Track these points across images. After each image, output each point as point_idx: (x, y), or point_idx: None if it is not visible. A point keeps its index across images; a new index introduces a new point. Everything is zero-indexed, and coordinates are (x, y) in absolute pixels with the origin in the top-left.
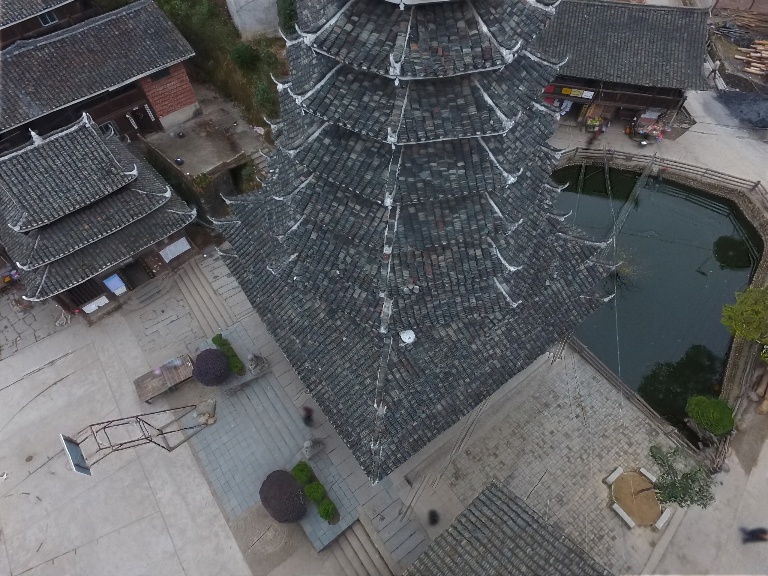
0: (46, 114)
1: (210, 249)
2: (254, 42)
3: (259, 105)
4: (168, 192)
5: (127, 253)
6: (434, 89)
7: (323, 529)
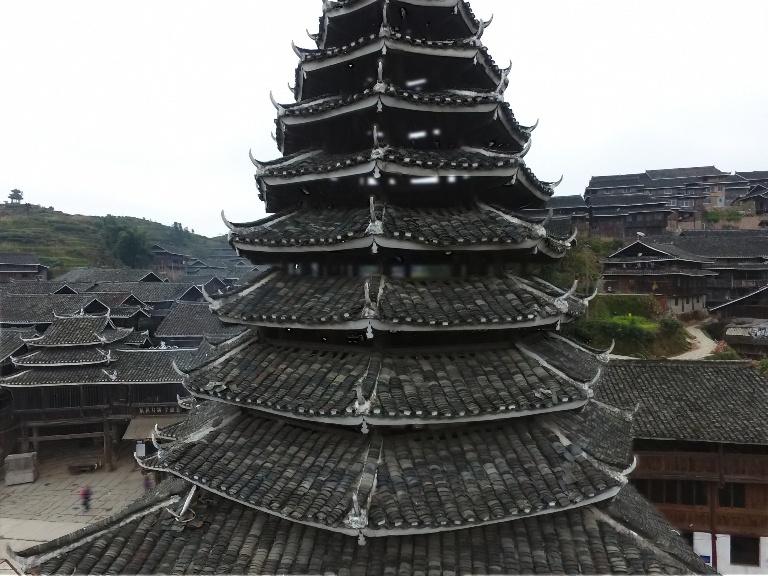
0: None
1: None
2: None
3: None
4: None
5: None
6: (338, 155)
7: None
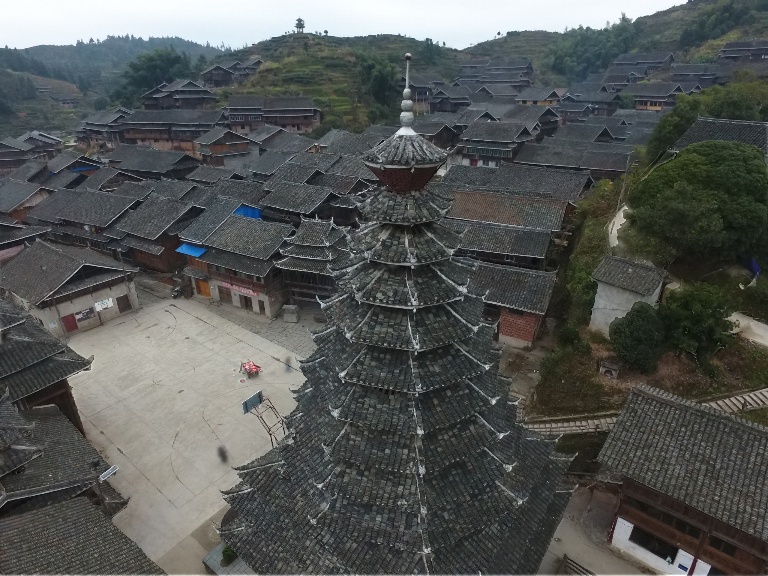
0: None
1: None
2: (592, 334)
3: (541, 366)
4: None
5: None
6: None
7: (218, 557)
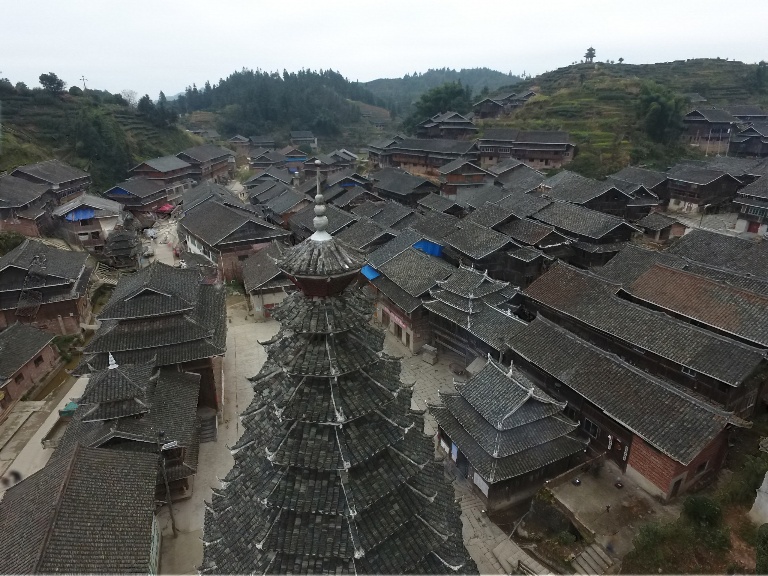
0: (566, 384)
1: (499, 521)
2: (749, 526)
3: None
4: (495, 454)
5: (458, 444)
6: None
7: None
